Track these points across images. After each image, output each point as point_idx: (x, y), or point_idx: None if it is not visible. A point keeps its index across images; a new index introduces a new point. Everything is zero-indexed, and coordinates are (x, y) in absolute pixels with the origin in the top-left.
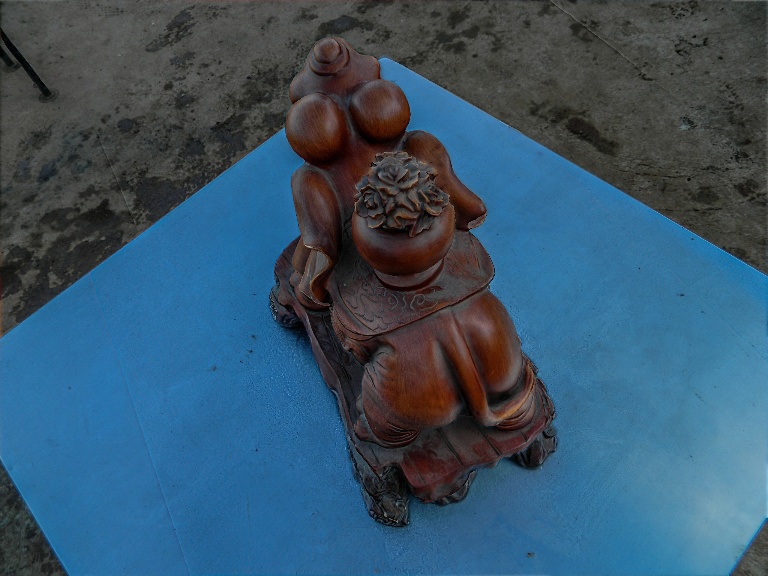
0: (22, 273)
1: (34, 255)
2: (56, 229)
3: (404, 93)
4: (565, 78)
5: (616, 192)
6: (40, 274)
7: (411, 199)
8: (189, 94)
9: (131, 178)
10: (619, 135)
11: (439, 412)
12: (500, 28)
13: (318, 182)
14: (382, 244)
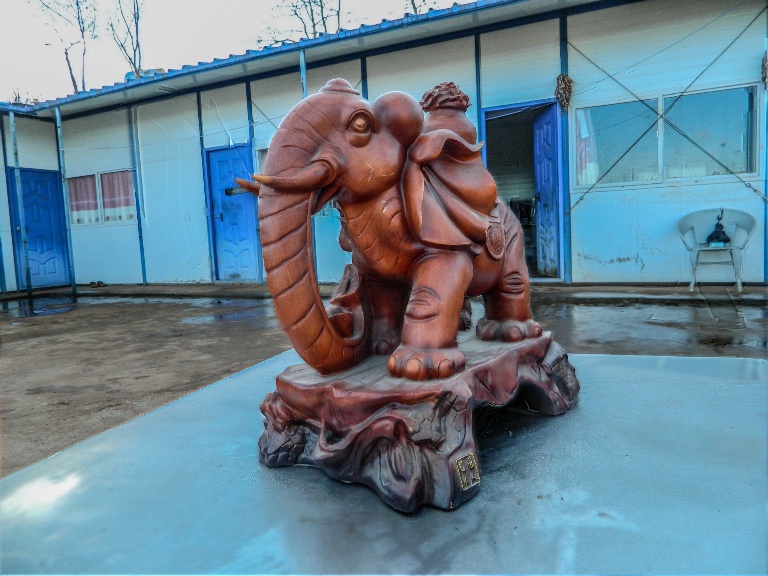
0: None
1: None
2: None
3: None
4: None
5: (181, 399)
6: None
7: None
8: None
9: None
10: None
11: None
12: None
13: None
14: None
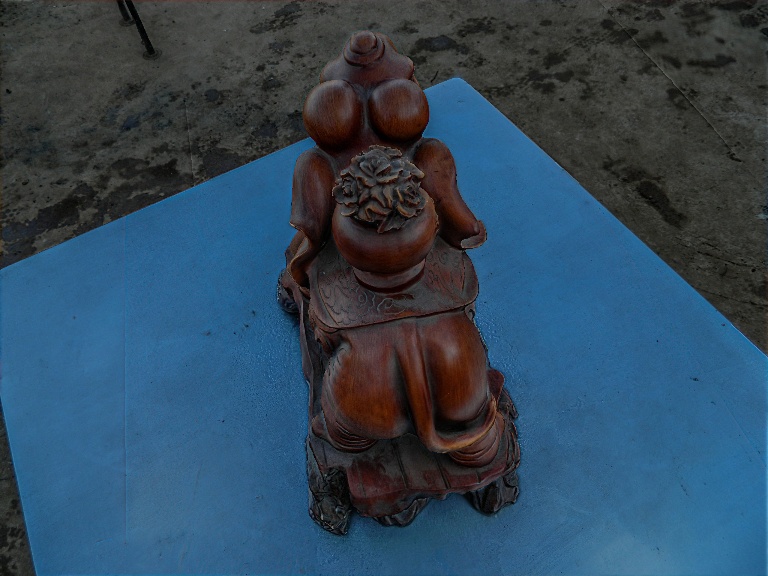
0: (82, 209)
1: (97, 195)
2: (123, 176)
3: (467, 115)
4: (648, 140)
5: (655, 259)
6: (97, 213)
7: (385, 194)
8: (277, 79)
9: (203, 145)
10: (690, 209)
11: (381, 422)
12: (595, 78)
13: (321, 166)
14: (353, 235)
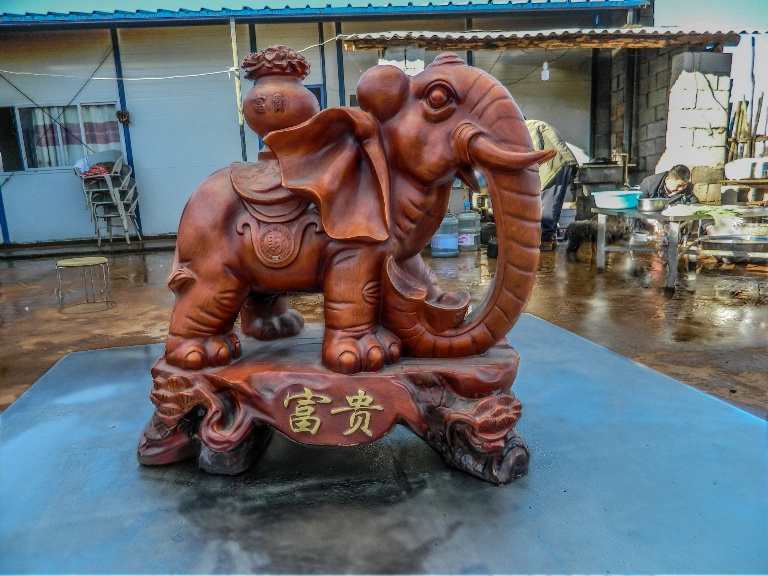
0: None
1: None
2: None
3: None
4: None
5: None
6: None
7: None
8: None
9: None
10: None
11: None
12: None
13: None
14: None
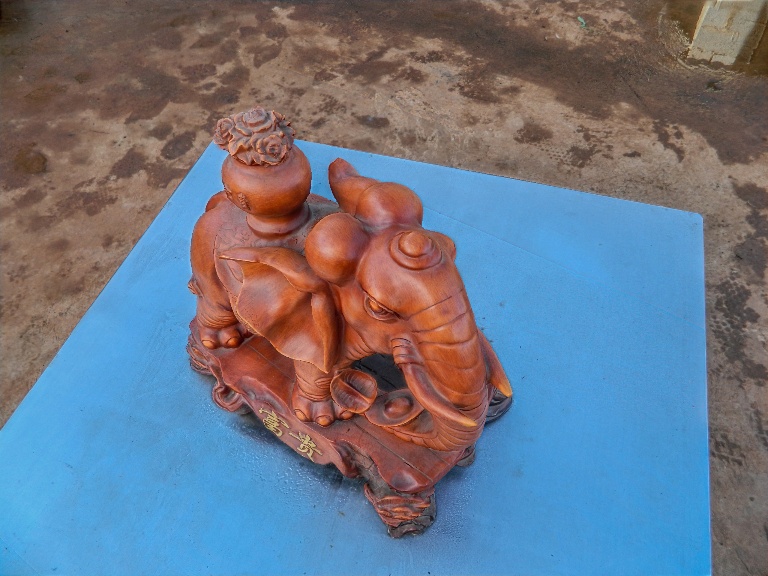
0: None
1: None
2: None
3: None
4: None
5: None
6: None
7: None
8: None
9: None
10: None
11: None
12: None
13: None
14: None
